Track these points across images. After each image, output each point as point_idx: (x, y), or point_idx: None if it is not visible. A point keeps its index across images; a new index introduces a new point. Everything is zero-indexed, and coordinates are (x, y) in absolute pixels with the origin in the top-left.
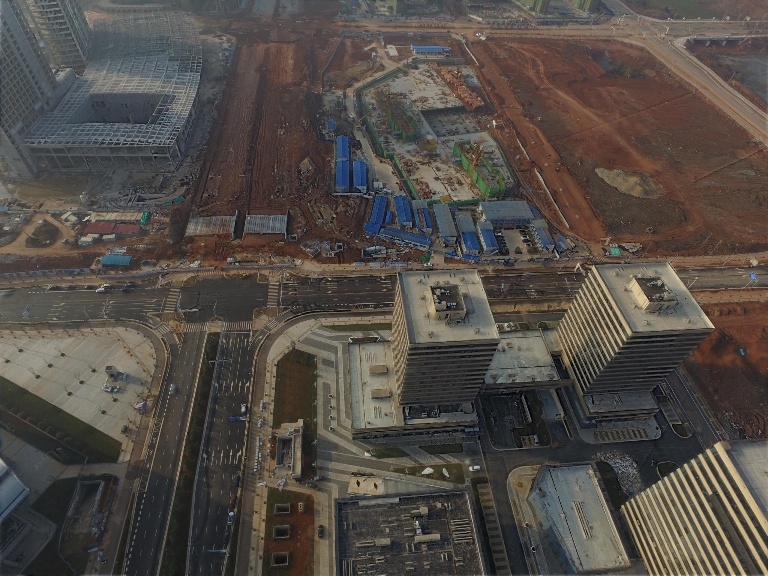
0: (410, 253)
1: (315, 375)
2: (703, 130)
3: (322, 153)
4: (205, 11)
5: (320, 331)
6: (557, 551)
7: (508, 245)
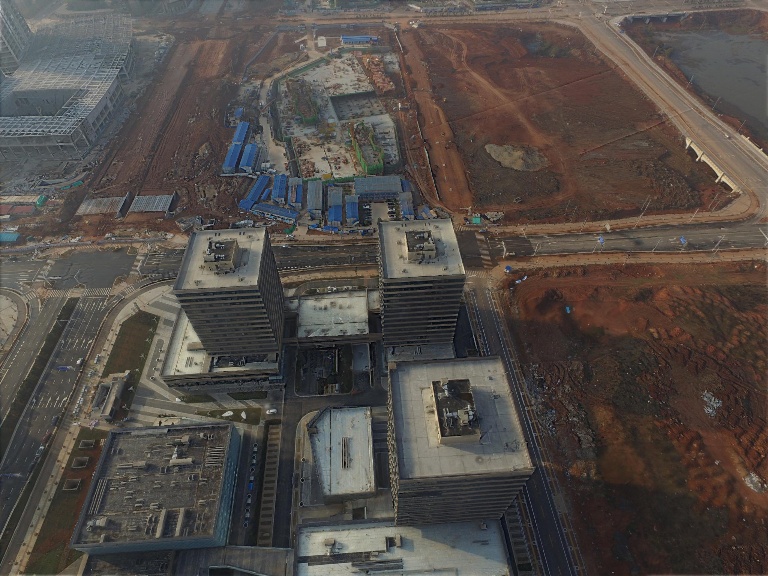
0: (275, 226)
1: (152, 333)
2: (610, 105)
3: (222, 138)
4: (153, 13)
5: (170, 295)
6: None
7: (373, 217)
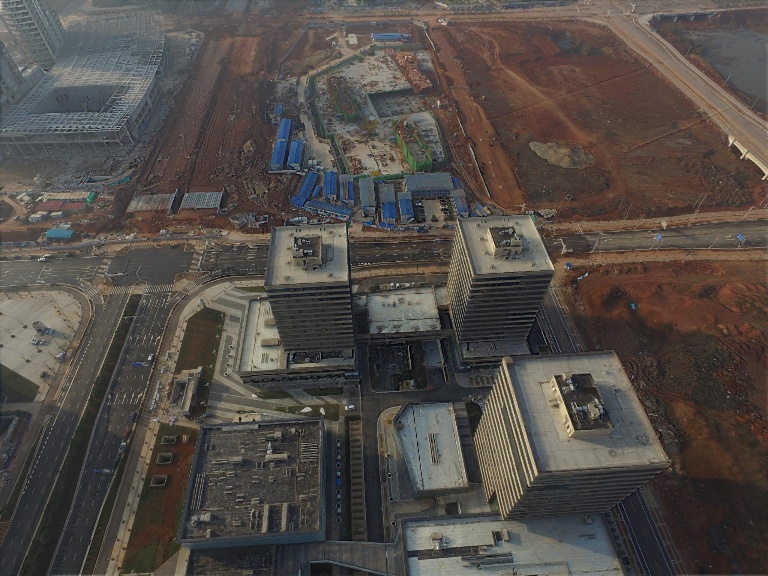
0: None
1: (220, 329)
2: (648, 103)
3: (265, 135)
4: (180, 10)
5: (233, 292)
6: (408, 476)
7: (426, 214)
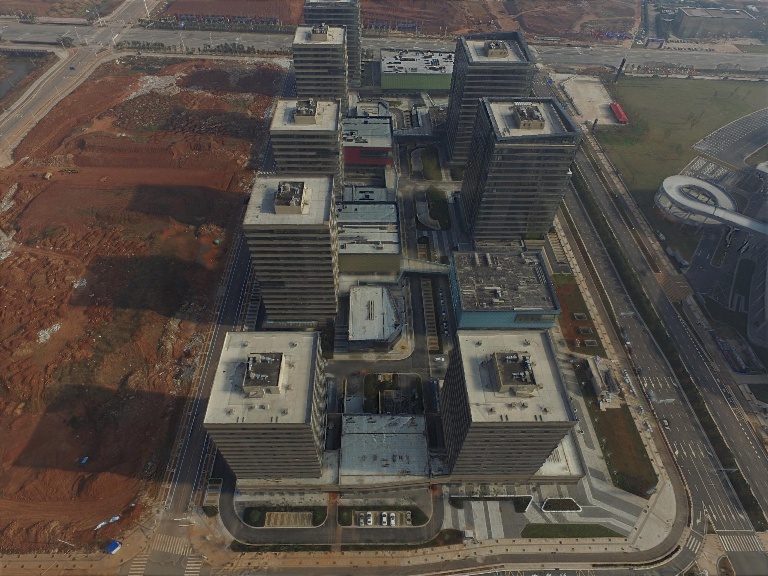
0: None
1: None
2: None
3: None
4: None
5: (624, 527)
6: None
7: None
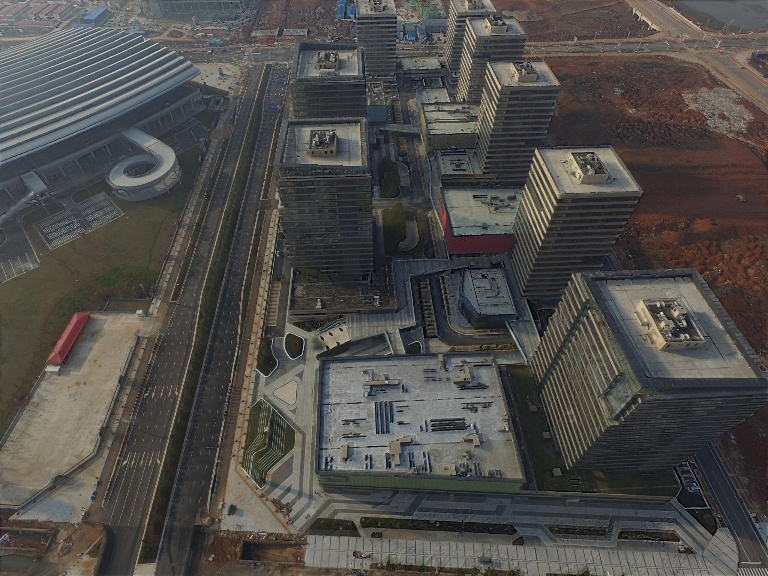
0: None
1: None
2: None
3: (329, 5)
4: None
5: None
6: None
7: (434, 38)
